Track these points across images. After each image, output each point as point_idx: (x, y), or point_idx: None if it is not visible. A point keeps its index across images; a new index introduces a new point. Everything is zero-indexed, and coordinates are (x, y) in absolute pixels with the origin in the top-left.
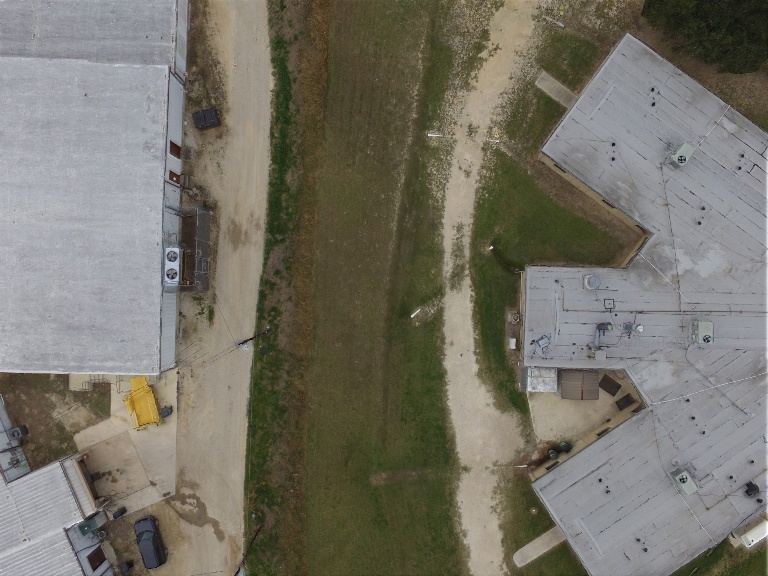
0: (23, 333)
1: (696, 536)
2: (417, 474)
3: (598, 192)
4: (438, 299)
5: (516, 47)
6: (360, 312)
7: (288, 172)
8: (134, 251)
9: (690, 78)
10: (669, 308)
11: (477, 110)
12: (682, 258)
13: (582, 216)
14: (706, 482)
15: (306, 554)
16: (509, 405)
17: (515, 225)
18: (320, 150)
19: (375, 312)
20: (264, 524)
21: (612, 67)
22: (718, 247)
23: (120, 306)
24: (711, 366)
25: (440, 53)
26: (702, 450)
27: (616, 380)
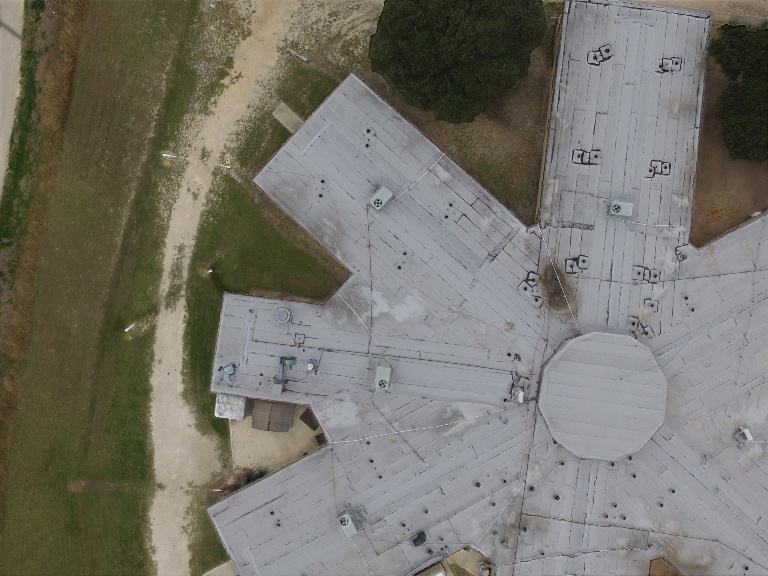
0: None
1: None
2: (115, 486)
3: (303, 227)
4: (152, 316)
5: (258, 77)
6: (76, 321)
7: (23, 178)
8: None
9: (408, 123)
10: (357, 349)
11: (212, 135)
12: (379, 301)
13: (303, 249)
14: (378, 527)
15: None
16: (210, 428)
17: (236, 251)
18: (56, 159)
19: (91, 322)
20: None
21: (332, 105)
22: (416, 293)
23: None
24: (396, 411)
25: (185, 76)
26: (376, 494)
27: None
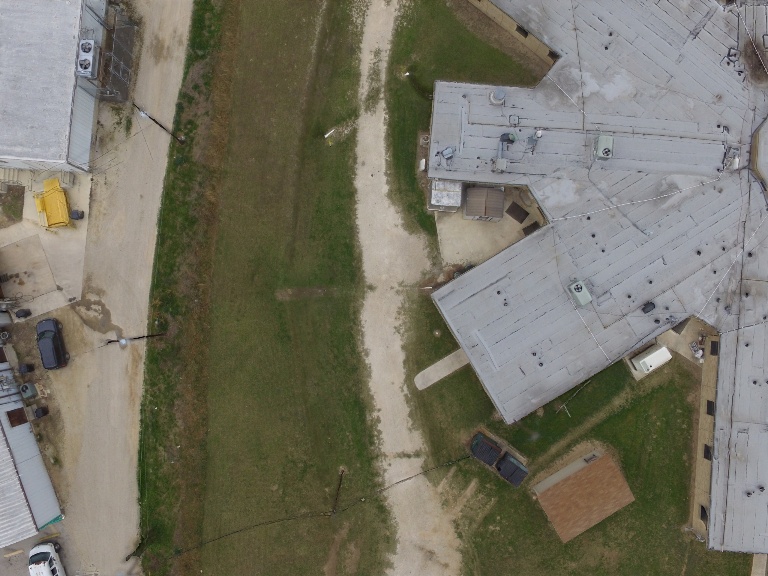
0: None
1: (593, 355)
2: (323, 292)
3: (508, 14)
4: (352, 120)
5: None
6: (275, 129)
7: None
8: (50, 42)
9: None
10: (573, 127)
11: None
12: (588, 81)
13: (497, 48)
14: (604, 300)
15: (207, 366)
16: (417, 227)
17: (431, 53)
18: None
19: (290, 130)
20: (167, 332)
21: None
22: (624, 73)
23: (32, 93)
24: (613, 187)
25: None
26: (601, 268)
27: (524, 208)
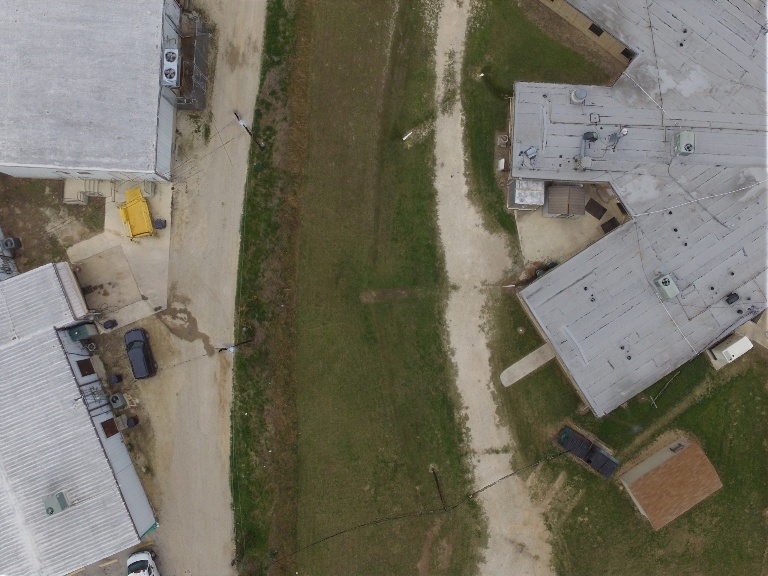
0: (21, 127)
1: (678, 346)
2: (407, 293)
3: (585, 13)
4: (430, 122)
5: None
6: (353, 133)
7: None
8: (133, 52)
9: None
10: (652, 123)
11: None
12: (665, 78)
13: (569, 47)
14: (688, 293)
15: (295, 371)
16: (497, 226)
17: (505, 54)
18: None
19: (368, 134)
20: (254, 338)
21: None
22: (699, 69)
23: (118, 104)
24: (693, 182)
25: None
26: (684, 261)
27: (601, 204)
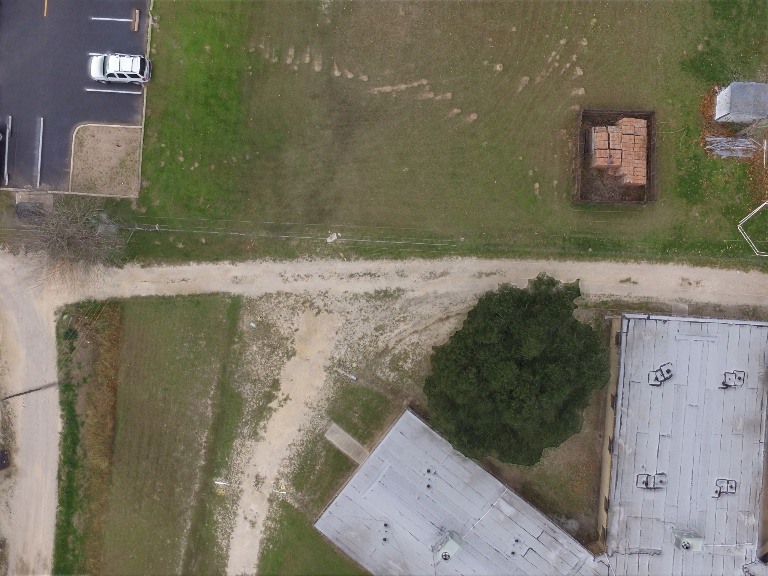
0: None
1: None
2: None
3: (368, 570)
4: None
5: (306, 398)
6: None
7: (75, 515)
8: None
9: (468, 459)
10: None
11: (264, 461)
12: None
13: (365, 570)
14: None
15: None
16: None
17: None
18: (107, 495)
19: None
20: None
21: (389, 445)
22: None
23: None
24: None
25: (230, 400)
26: None
27: None
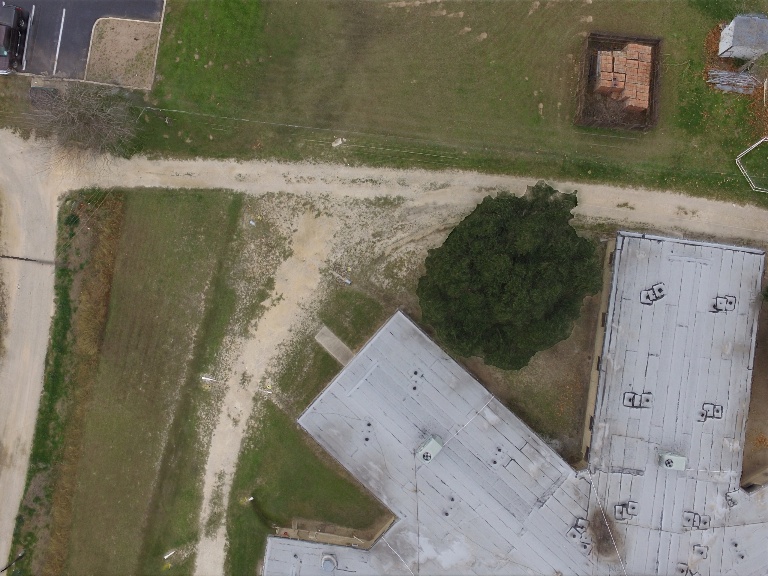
0: None
1: None
2: None
3: (349, 470)
4: (193, 544)
5: (299, 299)
6: (115, 547)
7: (58, 401)
8: None
9: (456, 364)
10: None
11: (253, 359)
12: (425, 547)
13: (346, 477)
14: None
15: None
16: None
17: (277, 479)
18: (92, 382)
19: (129, 549)
20: None
21: (378, 345)
22: (464, 539)
23: None
24: None
25: (224, 296)
26: None
27: None
